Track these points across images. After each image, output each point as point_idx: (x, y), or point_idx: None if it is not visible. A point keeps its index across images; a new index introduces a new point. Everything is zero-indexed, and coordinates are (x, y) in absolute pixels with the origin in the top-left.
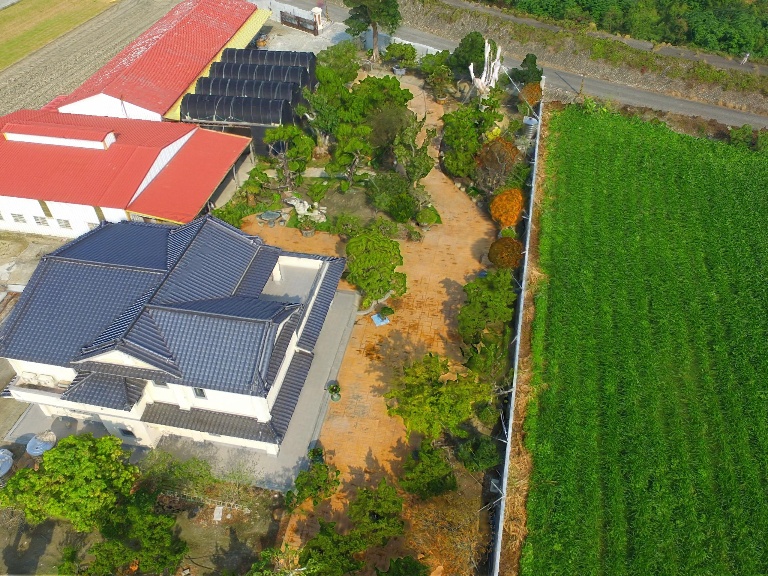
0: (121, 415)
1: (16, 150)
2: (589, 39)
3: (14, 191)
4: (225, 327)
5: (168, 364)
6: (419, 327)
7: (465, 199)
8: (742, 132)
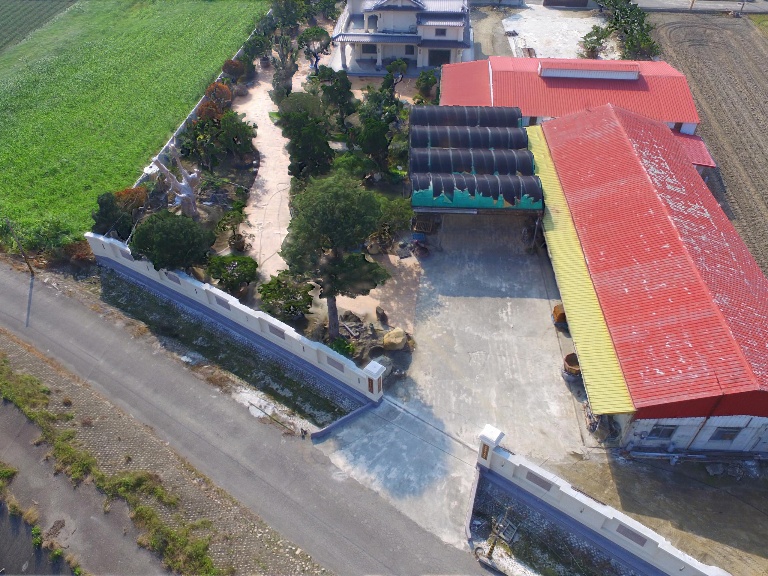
0: None
1: None
2: None
3: None
4: None
5: None
6: None
7: None
8: None
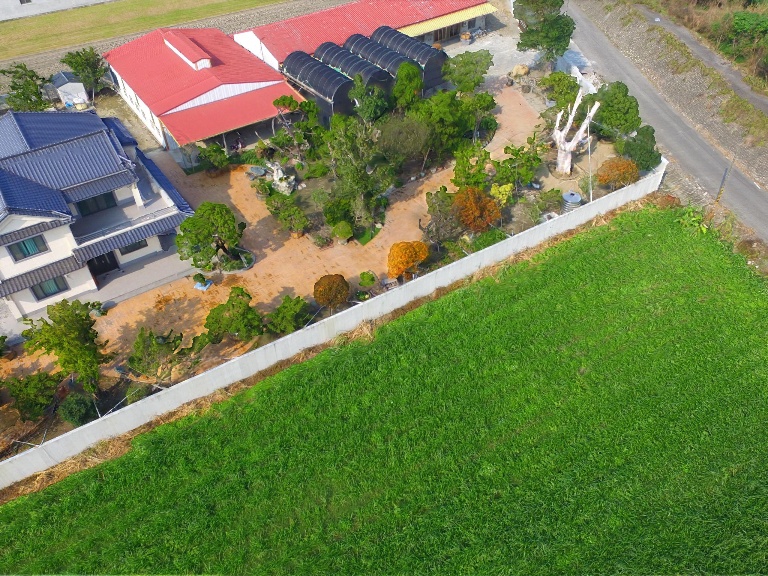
0: None
1: (161, 52)
2: None
3: (130, 78)
4: None
5: None
6: None
7: (417, 237)
8: None
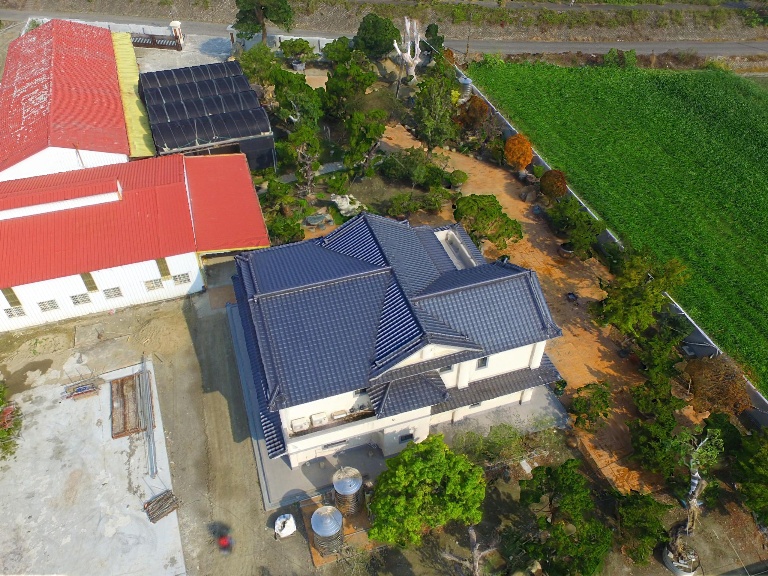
0: (410, 419)
1: (2, 231)
2: (447, 7)
3: (42, 274)
4: (493, 292)
5: (467, 342)
6: (529, 264)
7: (463, 157)
8: (611, 55)
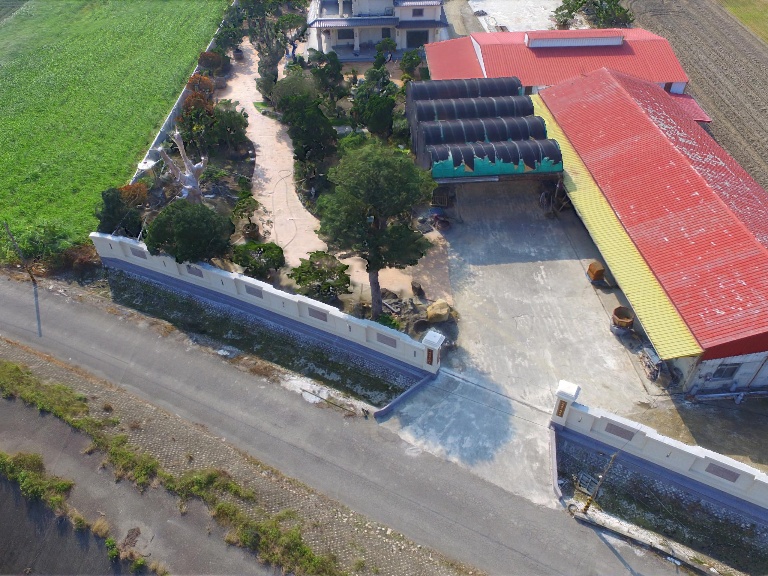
0: None
1: None
2: None
3: None
4: None
5: None
6: None
7: None
8: None
